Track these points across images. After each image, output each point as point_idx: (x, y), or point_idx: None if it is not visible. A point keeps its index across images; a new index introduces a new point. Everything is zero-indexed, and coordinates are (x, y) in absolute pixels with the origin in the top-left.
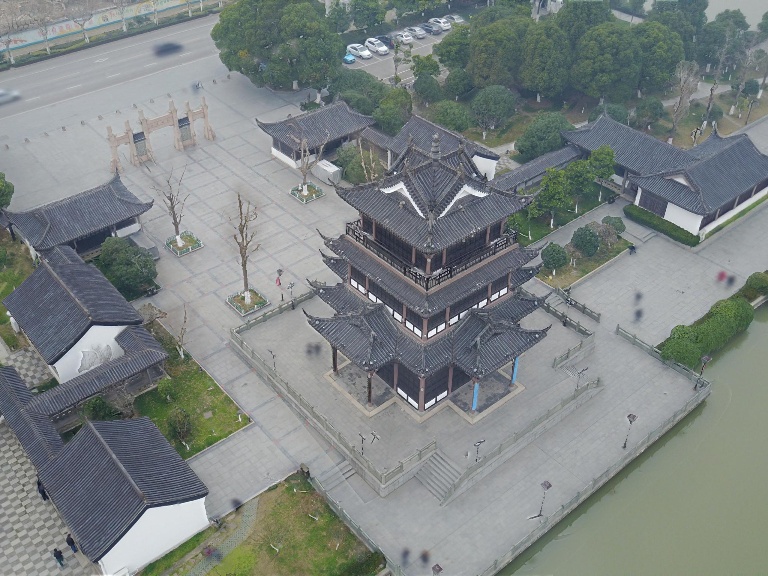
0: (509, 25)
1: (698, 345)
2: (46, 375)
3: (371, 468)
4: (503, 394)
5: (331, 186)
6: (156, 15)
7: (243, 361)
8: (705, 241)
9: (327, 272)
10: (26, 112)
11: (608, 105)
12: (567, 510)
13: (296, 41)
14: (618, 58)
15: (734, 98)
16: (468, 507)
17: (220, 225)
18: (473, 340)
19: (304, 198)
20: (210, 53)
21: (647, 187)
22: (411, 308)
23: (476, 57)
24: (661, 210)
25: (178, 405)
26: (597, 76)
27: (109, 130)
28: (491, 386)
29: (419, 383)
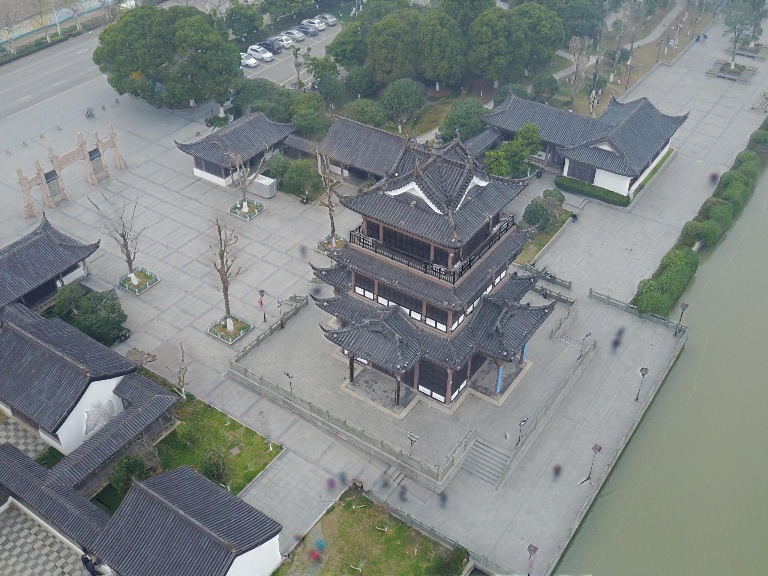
0: (399, 19)
1: (665, 295)
2: (40, 446)
3: (424, 468)
4: (516, 372)
5: (269, 199)
6: (13, 44)
7: (249, 390)
8: (634, 200)
9: (299, 285)
10: None
11: (511, 86)
12: (610, 468)
13: (194, 56)
14: (511, 40)
15: (608, 66)
16: (522, 486)
17: (169, 256)
18: (494, 325)
19: (246, 215)
20: (86, 79)
21: (575, 158)
22: (439, 304)
23: (376, 53)
24: (590, 177)
25: (200, 448)
26: (494, 59)
27: (19, 173)
28: (503, 367)
29: (447, 377)
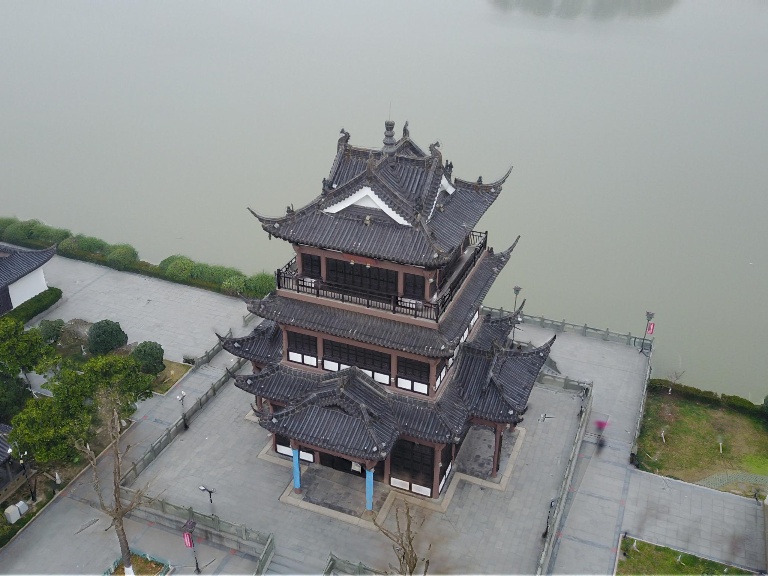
0: None
1: None
2: None
3: None
4: None
5: None
6: None
7: None
8: None
9: None
10: None
11: None
12: None
13: None
14: None
15: None
16: None
17: None
18: None
19: None
20: None
21: None
22: None
23: None
24: (5, 305)
25: None
26: None
27: None
28: None
29: None
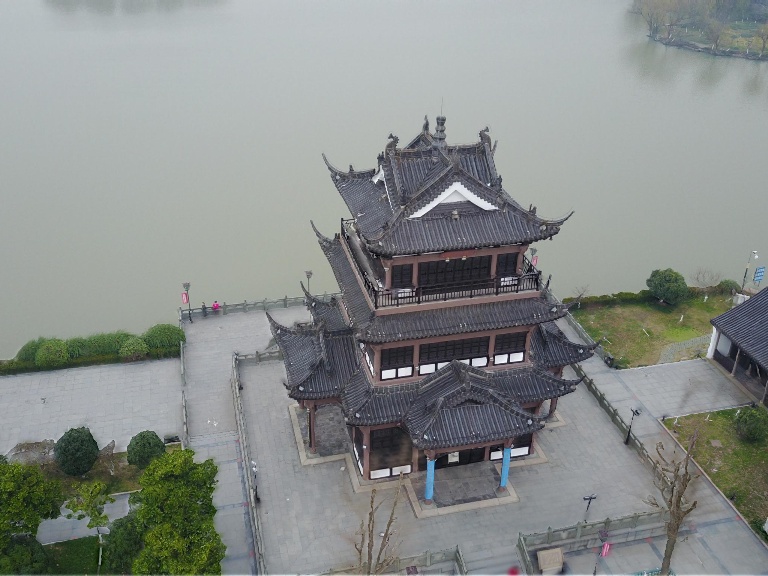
0: None
1: None
2: None
3: None
4: None
5: None
6: None
7: None
8: None
9: None
10: None
11: None
12: None
13: None
14: None
15: None
16: None
17: None
18: None
19: None
20: None
21: None
22: None
23: None
24: None
25: (759, 464)
26: None
27: None
28: None
29: None
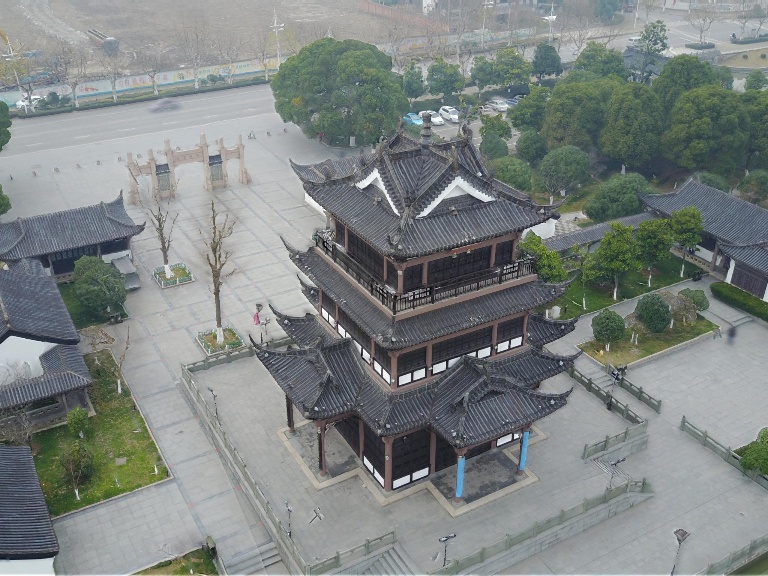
0: (594, 87)
1: None
2: None
3: (296, 555)
4: (505, 483)
5: None
6: (231, 75)
7: (189, 405)
8: None
9: None
10: (69, 147)
11: (703, 174)
12: None
13: (351, 88)
14: (719, 123)
15: None
16: None
17: None
18: (459, 395)
19: None
20: (274, 110)
21: (741, 258)
22: (373, 337)
23: (551, 116)
24: (759, 289)
25: (90, 445)
26: (692, 142)
27: (129, 157)
28: (491, 471)
29: (384, 448)
